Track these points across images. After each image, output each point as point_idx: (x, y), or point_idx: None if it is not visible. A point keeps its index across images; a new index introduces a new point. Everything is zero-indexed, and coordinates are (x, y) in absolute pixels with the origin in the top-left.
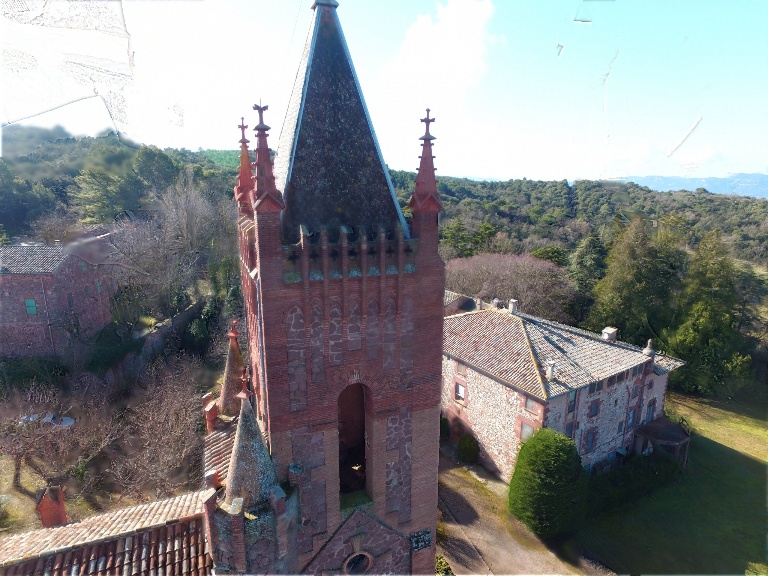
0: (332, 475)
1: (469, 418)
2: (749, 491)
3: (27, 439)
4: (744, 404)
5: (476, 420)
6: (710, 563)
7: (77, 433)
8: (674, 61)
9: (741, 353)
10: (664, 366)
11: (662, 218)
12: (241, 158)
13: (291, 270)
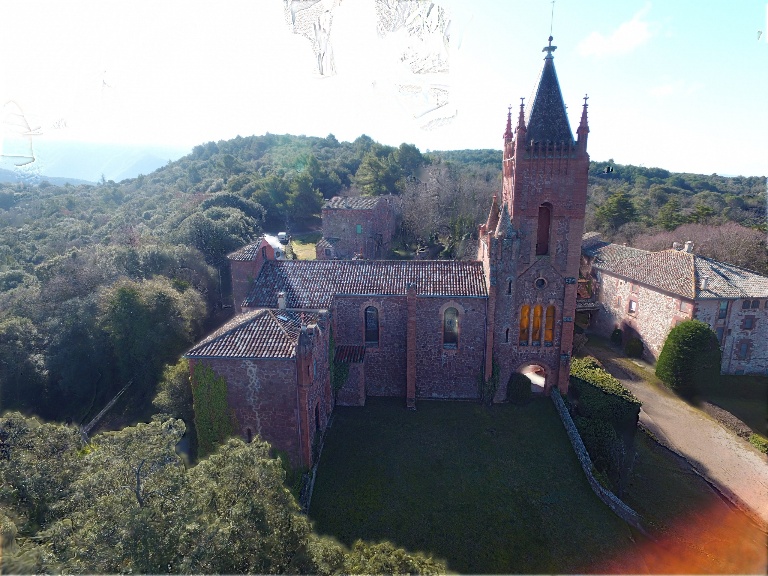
0: (534, 239)
1: (638, 326)
2: None
3: None
4: None
5: (643, 326)
6: None
7: None
8: None
9: None
10: None
11: None
12: (508, 121)
13: (527, 155)
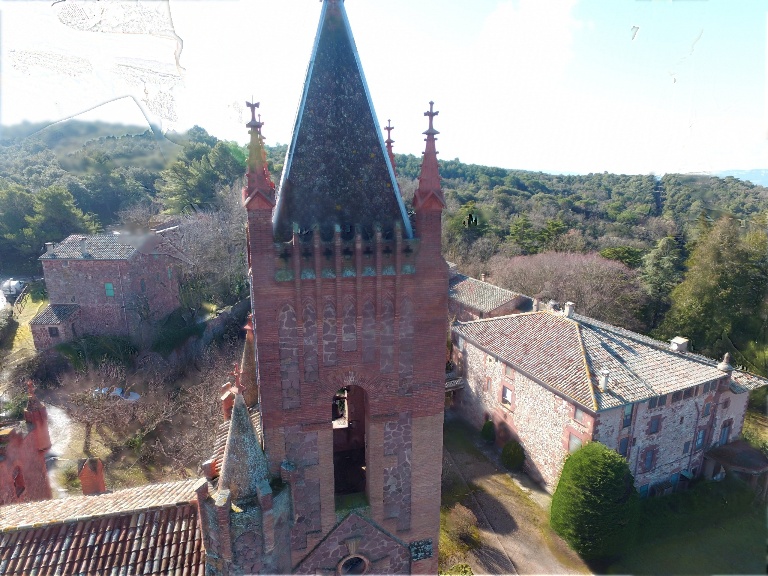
0: (326, 475)
1: (515, 424)
2: None
3: (97, 410)
4: None
5: (522, 426)
6: None
7: (141, 407)
8: None
9: None
10: (744, 384)
11: (751, 218)
12: None
13: (283, 268)
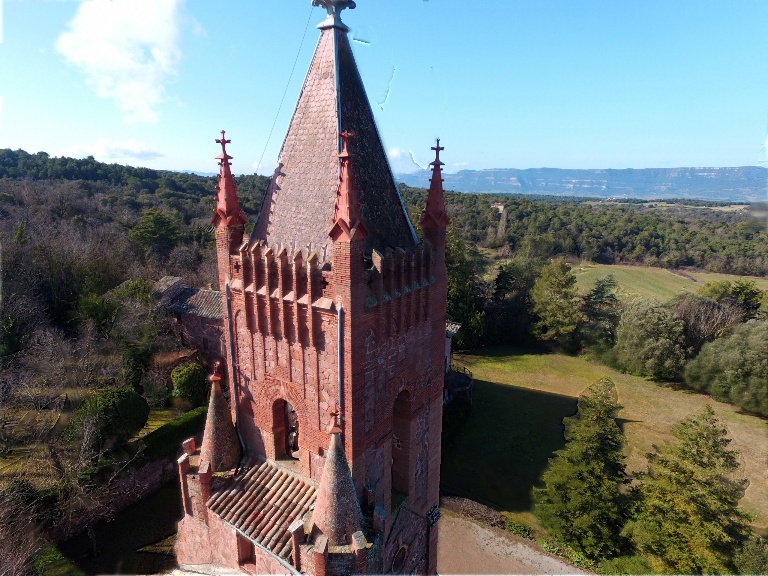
0: (387, 483)
1: None
2: (510, 408)
3: None
4: (483, 348)
5: None
6: (511, 466)
7: None
8: (425, 85)
9: (479, 311)
10: (451, 330)
11: None
12: (225, 177)
13: (369, 294)
